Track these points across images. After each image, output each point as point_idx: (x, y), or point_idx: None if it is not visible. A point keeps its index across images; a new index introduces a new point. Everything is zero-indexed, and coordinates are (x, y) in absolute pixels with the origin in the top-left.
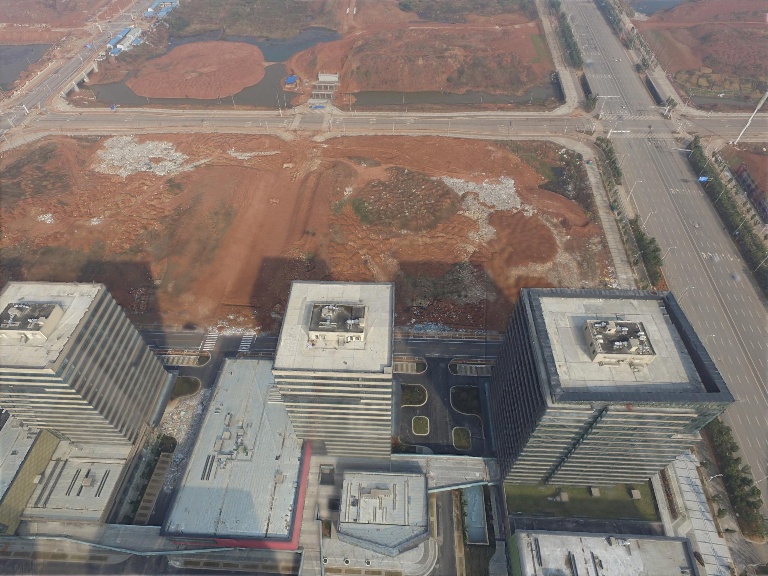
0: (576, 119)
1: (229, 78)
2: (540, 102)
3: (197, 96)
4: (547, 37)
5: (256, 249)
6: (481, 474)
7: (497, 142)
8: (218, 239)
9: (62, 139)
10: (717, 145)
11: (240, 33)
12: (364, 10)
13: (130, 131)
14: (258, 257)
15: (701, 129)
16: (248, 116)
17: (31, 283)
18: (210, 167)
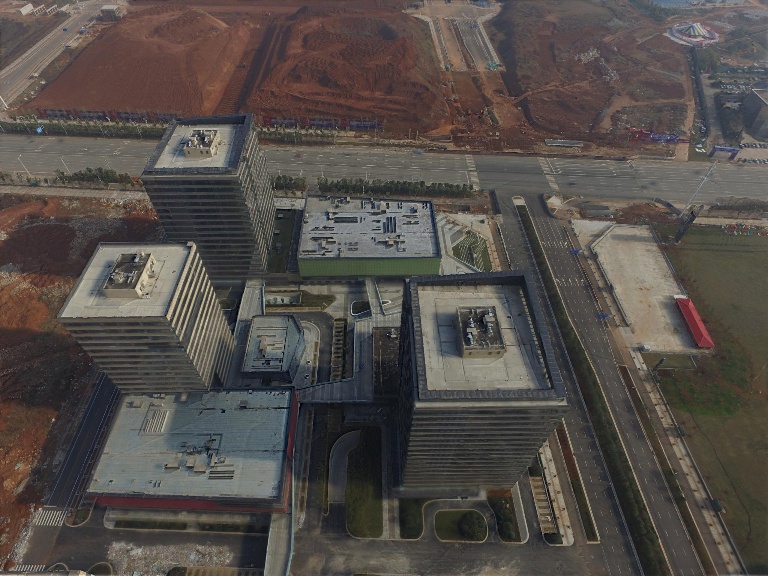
0: None
1: None
2: None
3: None
4: None
5: None
6: (257, 290)
7: None
8: None
9: None
10: (1, 116)
11: None
12: None
13: None
14: None
15: None
16: None
17: None
18: None
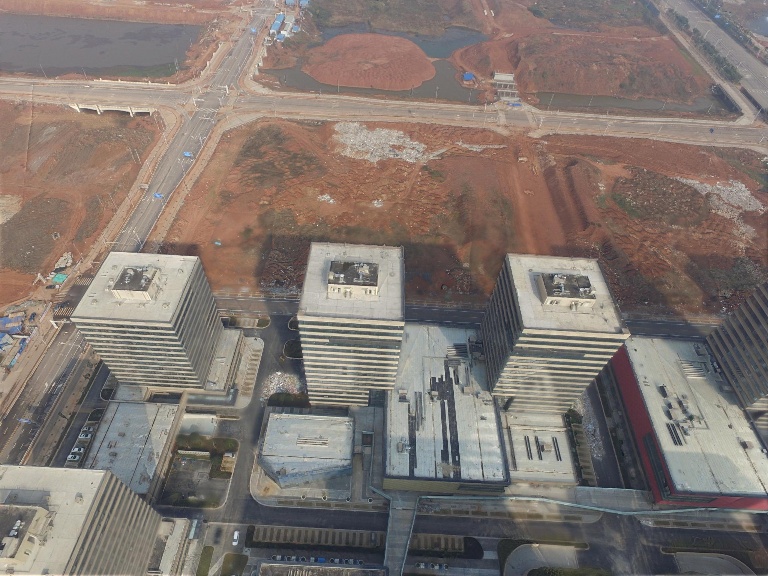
0: (761, 130)
1: (407, 71)
2: (714, 112)
3: (382, 87)
4: (691, 51)
5: (540, 237)
6: None
7: (702, 147)
8: (510, 226)
9: (280, 122)
10: None
11: (387, 27)
12: (504, 13)
13: (344, 117)
14: (547, 245)
15: None
16: (452, 109)
17: (527, 256)
18: (457, 157)
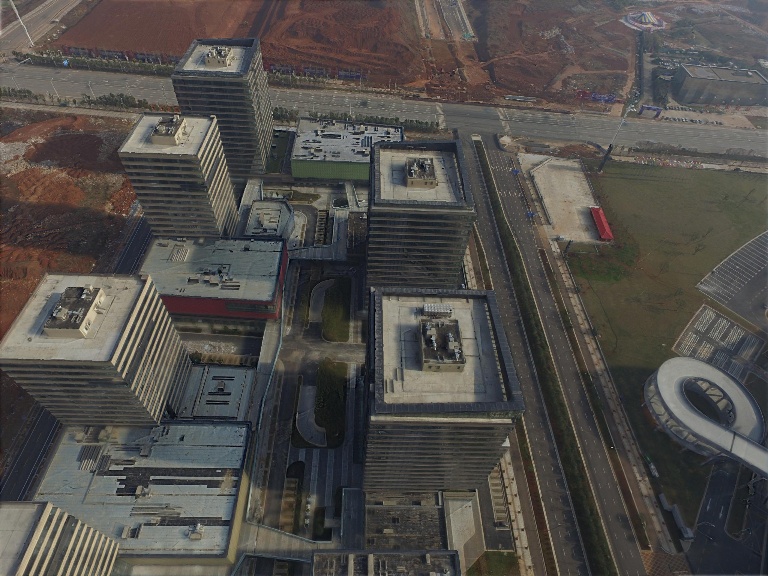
0: None
1: None
2: None
3: None
4: None
5: None
6: (256, 186)
7: None
8: None
9: None
10: None
11: None
12: None
13: None
14: None
15: (2, 51)
16: None
17: (6, 338)
18: None
